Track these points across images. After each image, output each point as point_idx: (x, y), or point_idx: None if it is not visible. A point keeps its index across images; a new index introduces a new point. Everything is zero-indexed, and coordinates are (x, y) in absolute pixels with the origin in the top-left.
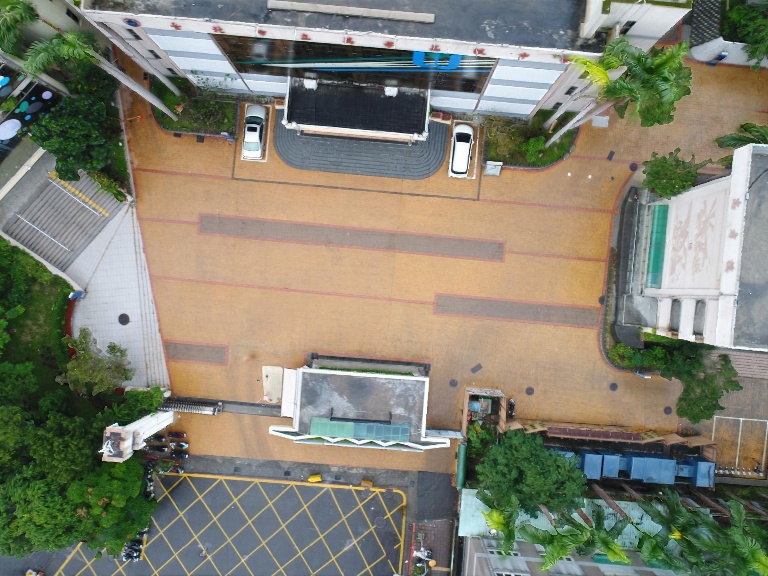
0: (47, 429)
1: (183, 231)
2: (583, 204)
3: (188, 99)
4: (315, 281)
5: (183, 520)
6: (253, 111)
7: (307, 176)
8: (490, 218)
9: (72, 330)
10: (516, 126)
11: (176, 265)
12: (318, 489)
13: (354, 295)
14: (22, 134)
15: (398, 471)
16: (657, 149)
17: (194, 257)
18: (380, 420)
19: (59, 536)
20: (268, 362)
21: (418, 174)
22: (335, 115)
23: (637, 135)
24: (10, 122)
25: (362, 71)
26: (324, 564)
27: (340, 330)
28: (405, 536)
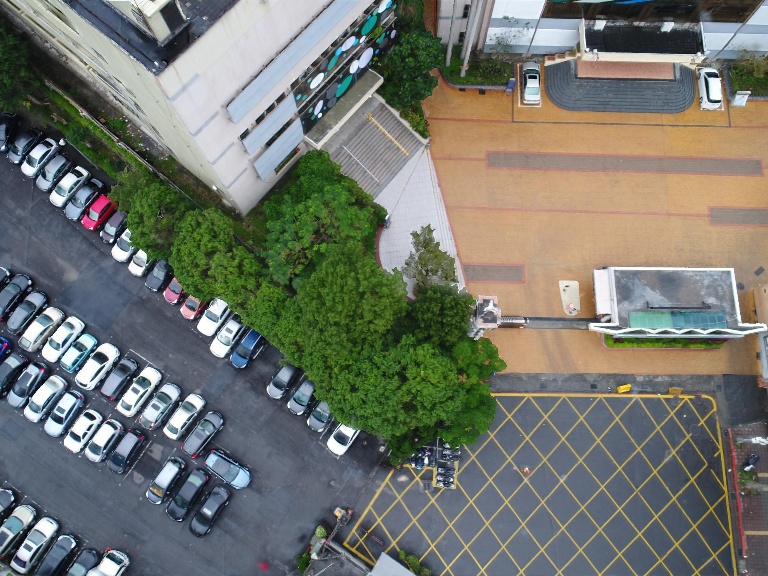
0: None
1: (473, 167)
2: None
3: (471, 61)
4: (597, 202)
5: (495, 442)
6: (528, 66)
7: (578, 116)
8: (744, 141)
9: (379, 256)
10: (751, 67)
11: (469, 196)
12: (627, 400)
13: (635, 212)
14: (366, 68)
15: (703, 376)
16: None
17: (485, 188)
18: None
19: (446, 401)
20: (563, 277)
21: (676, 108)
22: (621, 48)
23: None
24: (370, 50)
25: (658, 0)
26: (646, 479)
27: (626, 244)
28: (723, 443)
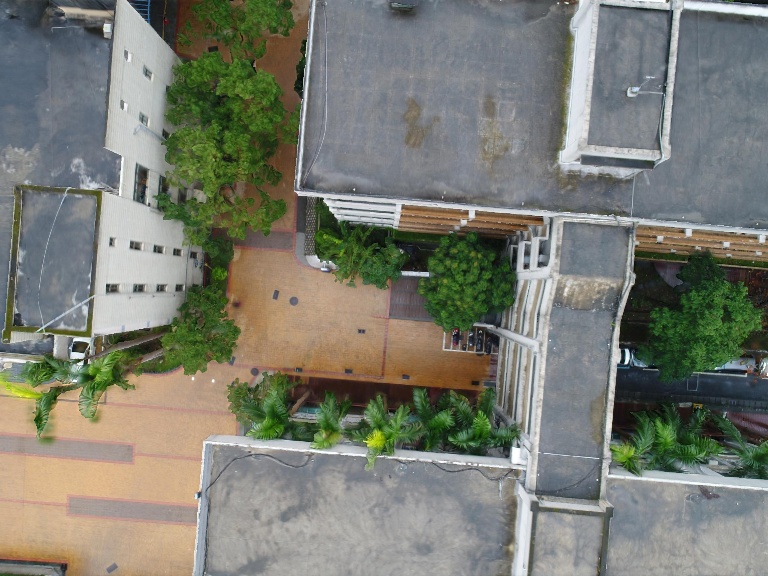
0: None
1: None
2: (208, 407)
3: None
4: None
5: None
6: None
7: None
8: (118, 421)
9: None
10: (137, 332)
11: None
12: None
13: None
14: None
15: None
16: (277, 354)
17: None
18: None
19: None
20: None
21: None
22: None
23: (256, 341)
24: None
25: None
26: None
27: None
28: None
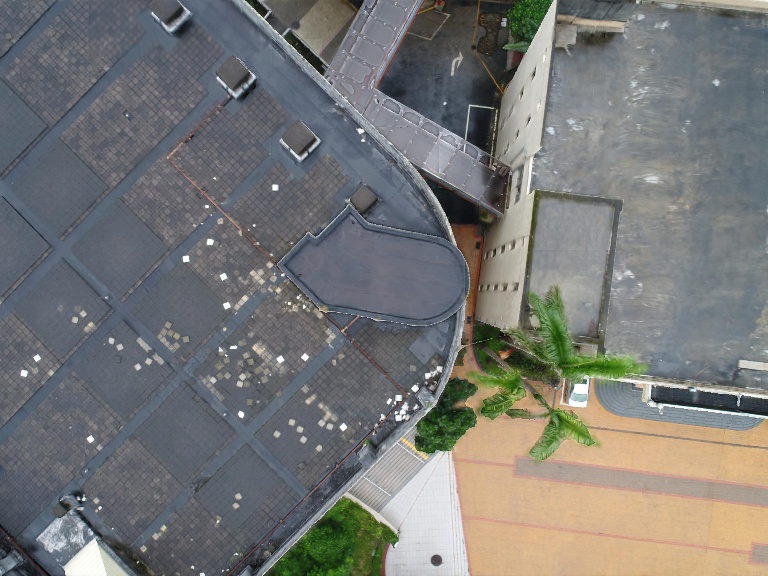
0: None
1: (498, 473)
2: None
3: None
4: (630, 527)
5: None
6: None
7: (627, 423)
8: None
9: (384, 570)
10: None
11: (489, 506)
12: None
13: (669, 542)
14: None
15: None
16: None
17: (508, 499)
18: None
19: None
20: None
21: (743, 426)
22: None
23: None
24: None
25: None
26: None
27: (653, 575)
28: None
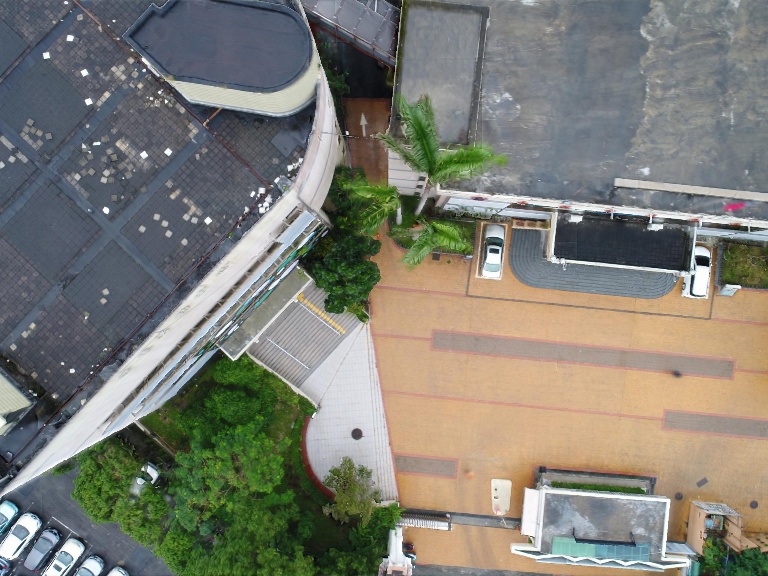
0: (336, 570)
1: (416, 347)
2: None
3: (427, 218)
4: (546, 397)
5: None
6: (492, 231)
7: (541, 294)
8: (721, 337)
9: (306, 445)
10: (751, 248)
11: (408, 380)
12: None
13: (584, 411)
14: None
15: None
16: None
17: (426, 372)
18: (624, 541)
19: None
20: (497, 475)
21: (653, 294)
22: (597, 248)
23: None
24: (294, 263)
25: None
26: None
27: (569, 444)
28: None
